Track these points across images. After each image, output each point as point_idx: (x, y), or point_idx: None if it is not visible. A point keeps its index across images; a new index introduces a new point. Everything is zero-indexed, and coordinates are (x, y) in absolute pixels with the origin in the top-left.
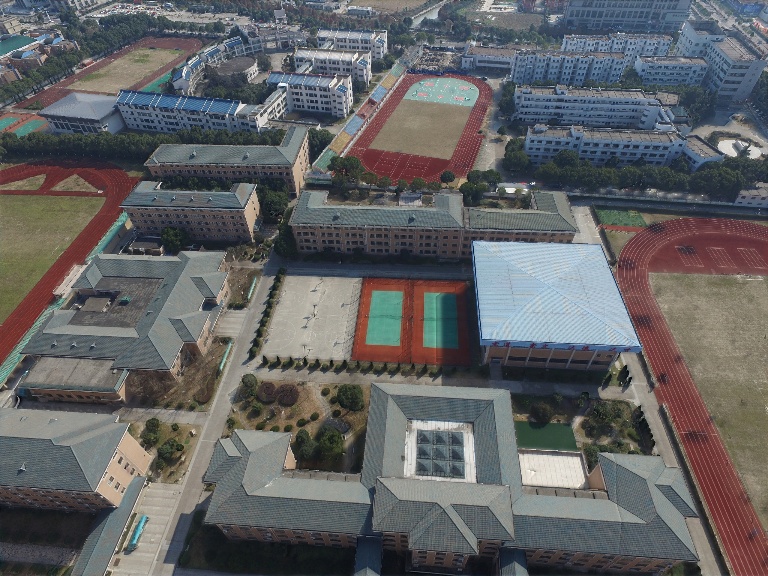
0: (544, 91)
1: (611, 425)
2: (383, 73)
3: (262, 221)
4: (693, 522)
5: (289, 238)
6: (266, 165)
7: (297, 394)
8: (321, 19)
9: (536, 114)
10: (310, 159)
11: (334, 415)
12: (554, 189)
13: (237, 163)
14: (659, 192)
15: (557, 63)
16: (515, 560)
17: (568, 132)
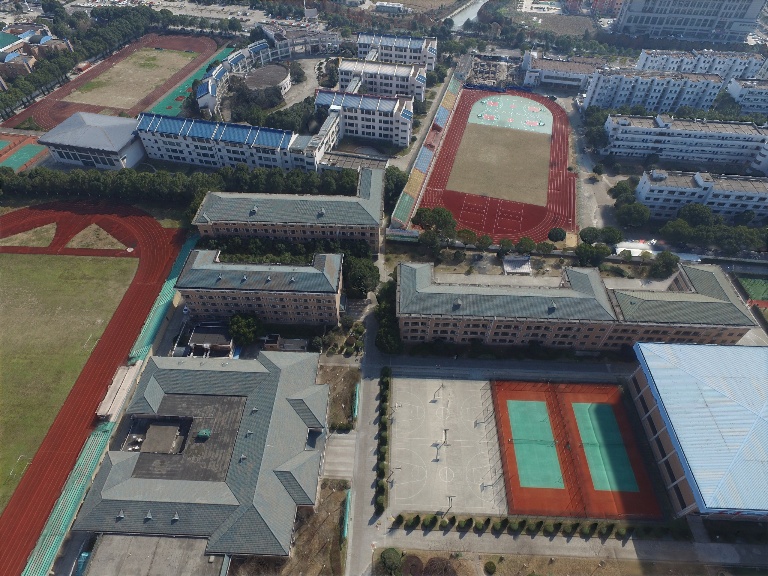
0: (643, 122)
1: None
2: (436, 88)
3: (345, 296)
4: None
5: (394, 329)
6: (347, 225)
7: (455, 575)
8: (349, 17)
9: (631, 148)
10: None
11: None
12: (683, 251)
13: (310, 222)
14: None
15: (645, 85)
16: None
17: (692, 180)
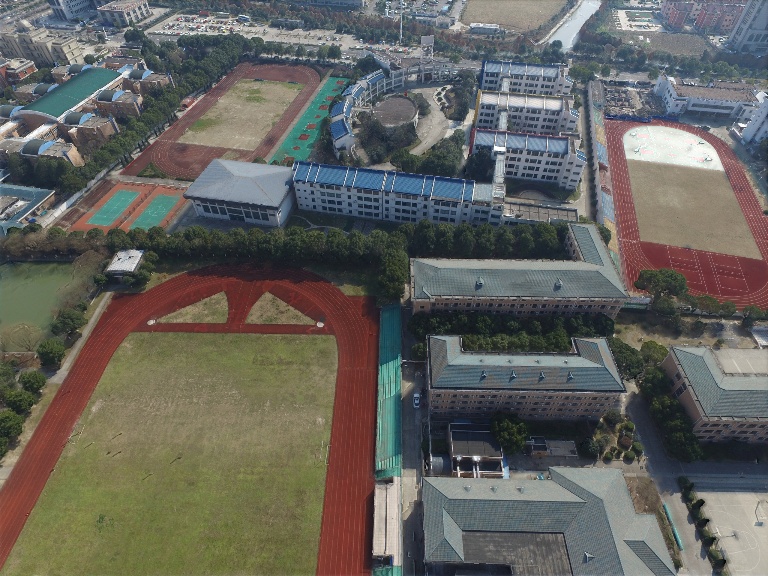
0: None
1: None
2: None
3: None
4: None
5: None
6: (591, 299)
7: None
8: (450, 41)
9: None
10: None
11: None
12: None
13: (547, 296)
14: None
15: None
16: None
17: None
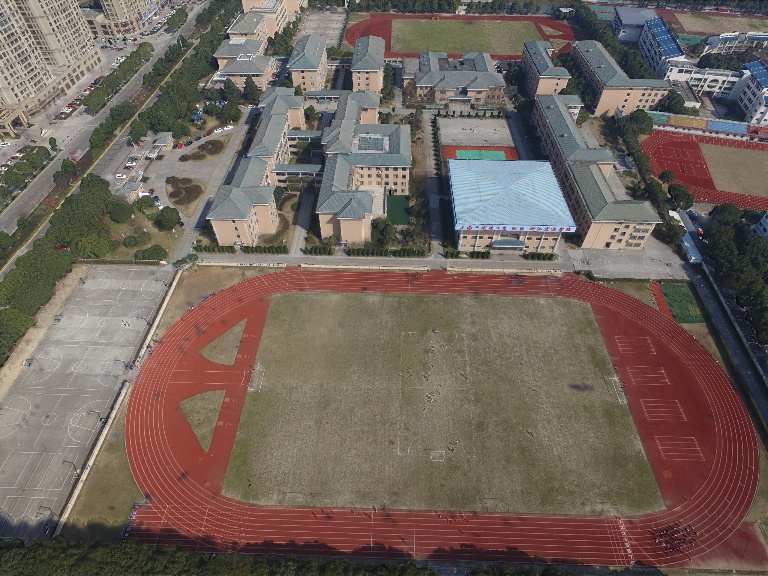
0: None
1: (411, 241)
2: None
3: None
4: (349, 262)
5: (530, 105)
6: (598, 77)
7: None
8: None
9: None
10: None
11: None
12: (701, 250)
13: (593, 67)
14: (762, 345)
15: None
16: (322, 165)
17: None
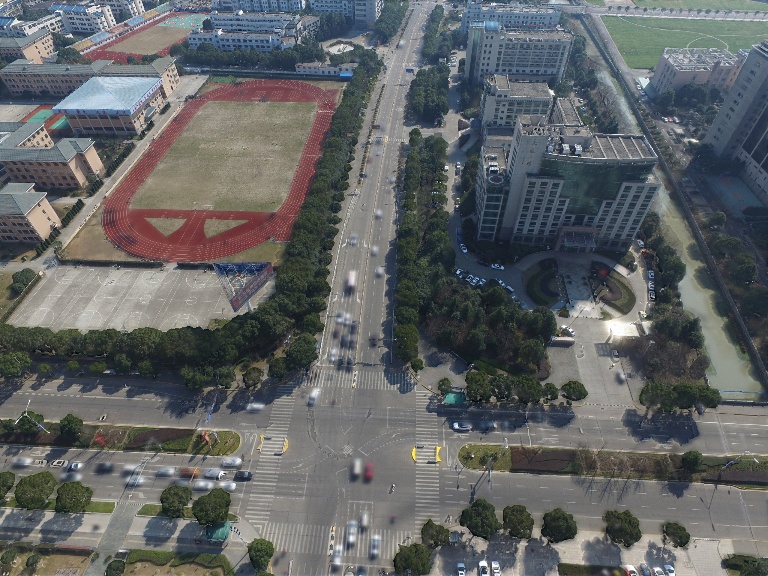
0: (229, 14)
1: None
2: None
3: None
4: (117, 176)
5: None
6: (4, 48)
7: None
8: None
9: None
10: None
11: None
12: (195, 66)
13: None
14: (257, 67)
15: None
16: None
17: None
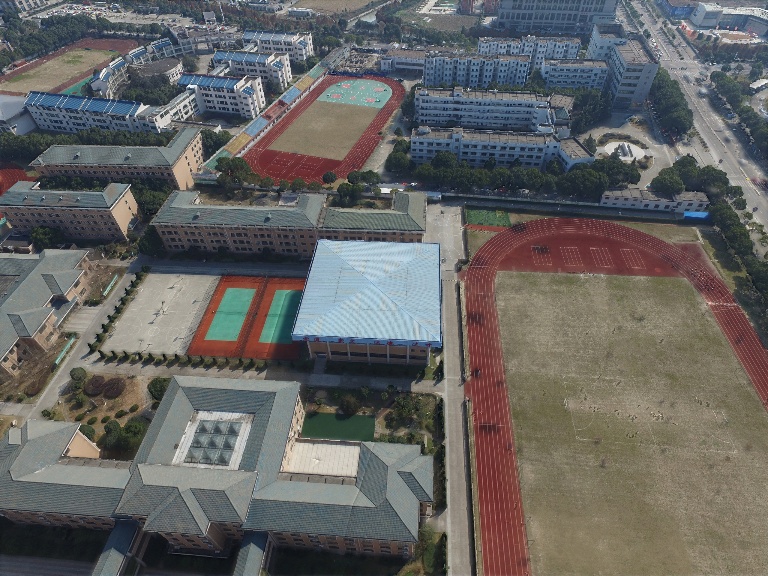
0: (442, 93)
1: (412, 417)
2: None
3: (140, 220)
4: (460, 508)
5: (153, 237)
6: (146, 166)
7: (123, 387)
8: (259, 20)
9: (436, 116)
10: (206, 160)
11: (153, 407)
12: (430, 190)
13: (119, 164)
14: (530, 193)
15: (464, 65)
16: (252, 541)
17: (450, 134)
